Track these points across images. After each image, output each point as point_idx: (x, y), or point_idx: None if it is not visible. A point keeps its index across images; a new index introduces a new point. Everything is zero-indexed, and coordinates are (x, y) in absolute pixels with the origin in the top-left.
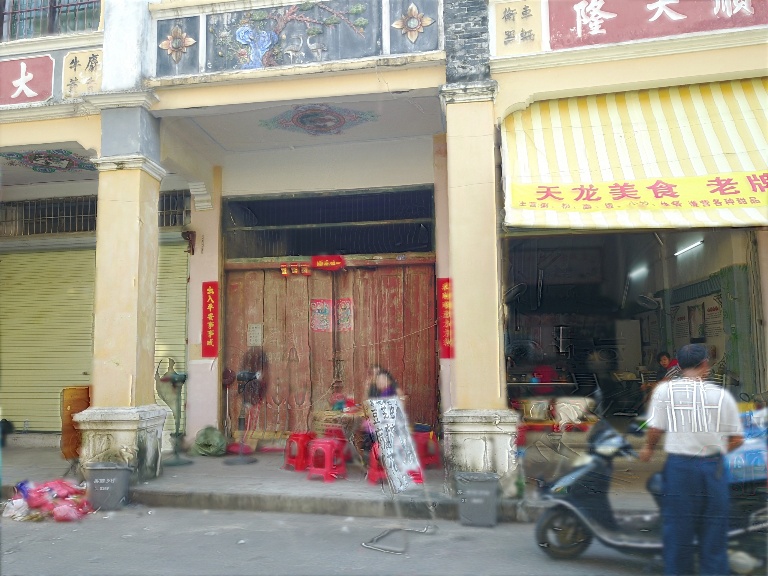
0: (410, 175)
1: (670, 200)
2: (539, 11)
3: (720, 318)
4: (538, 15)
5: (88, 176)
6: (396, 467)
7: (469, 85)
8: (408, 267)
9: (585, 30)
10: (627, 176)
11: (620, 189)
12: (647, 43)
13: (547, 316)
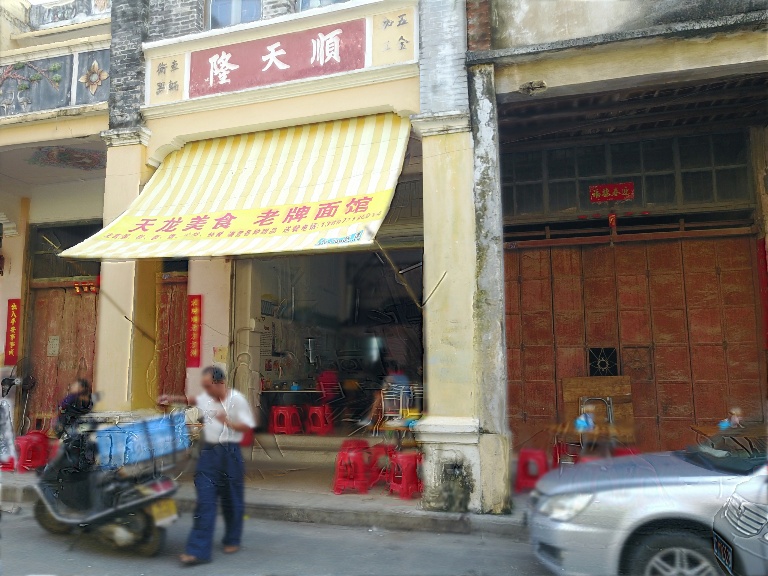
0: None
1: (219, 231)
2: (183, 65)
3: None
4: (182, 68)
5: None
6: None
7: (120, 131)
8: (176, 285)
9: (215, 80)
10: (212, 209)
11: (197, 221)
12: (254, 91)
13: (299, 329)
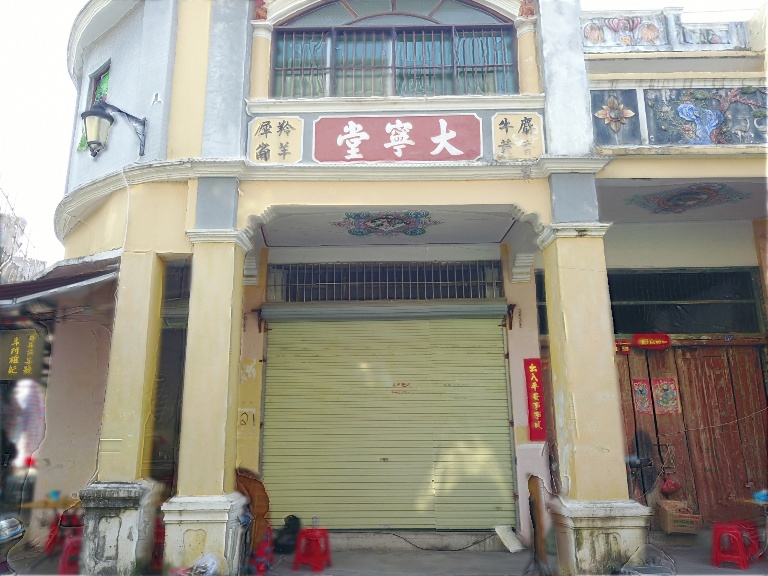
0: (733, 257)
1: None
2: None
3: None
4: None
5: (394, 241)
6: None
7: None
8: (731, 348)
9: None
10: None
11: None
12: None
13: None
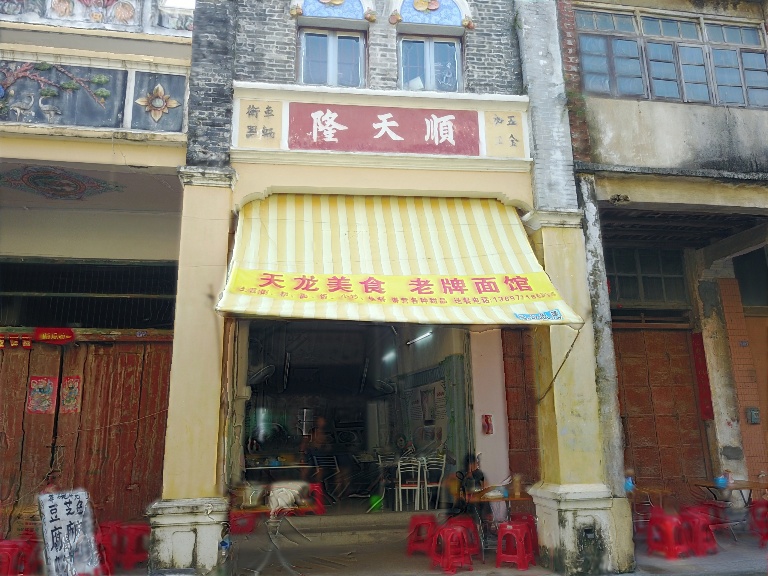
0: (159, 250)
1: (377, 295)
2: (280, 113)
3: (445, 402)
4: (279, 116)
5: None
6: (74, 571)
7: (208, 170)
8: (150, 345)
9: (320, 136)
10: (345, 271)
11: (337, 282)
12: (371, 156)
13: (292, 399)
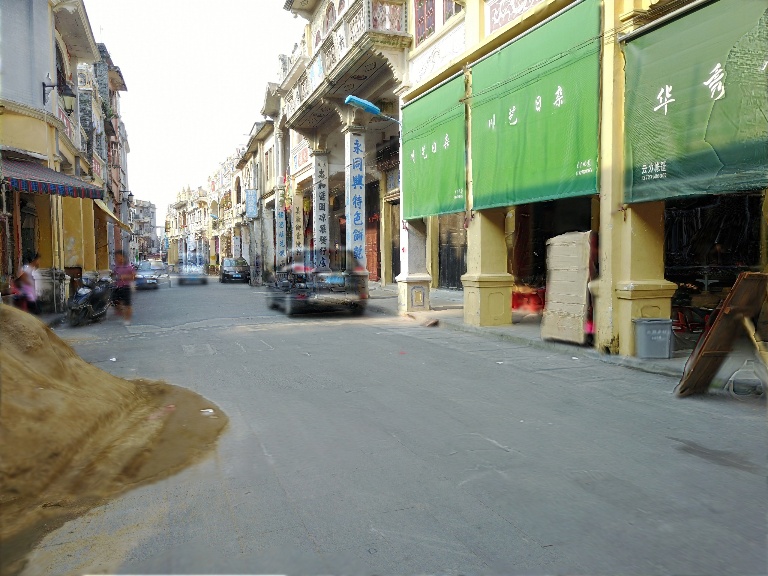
0: None
1: None
2: None
3: None
4: None
5: None
6: None
7: None
8: None
9: None
10: None
11: None
12: None
13: None
